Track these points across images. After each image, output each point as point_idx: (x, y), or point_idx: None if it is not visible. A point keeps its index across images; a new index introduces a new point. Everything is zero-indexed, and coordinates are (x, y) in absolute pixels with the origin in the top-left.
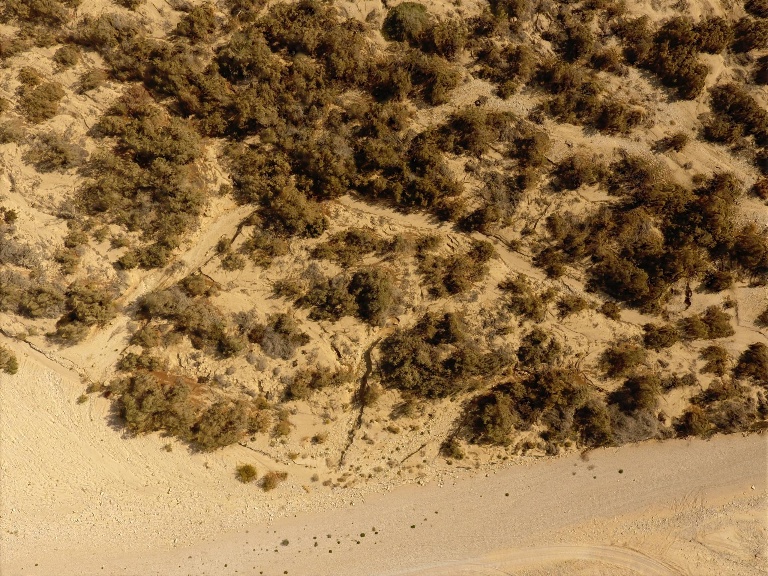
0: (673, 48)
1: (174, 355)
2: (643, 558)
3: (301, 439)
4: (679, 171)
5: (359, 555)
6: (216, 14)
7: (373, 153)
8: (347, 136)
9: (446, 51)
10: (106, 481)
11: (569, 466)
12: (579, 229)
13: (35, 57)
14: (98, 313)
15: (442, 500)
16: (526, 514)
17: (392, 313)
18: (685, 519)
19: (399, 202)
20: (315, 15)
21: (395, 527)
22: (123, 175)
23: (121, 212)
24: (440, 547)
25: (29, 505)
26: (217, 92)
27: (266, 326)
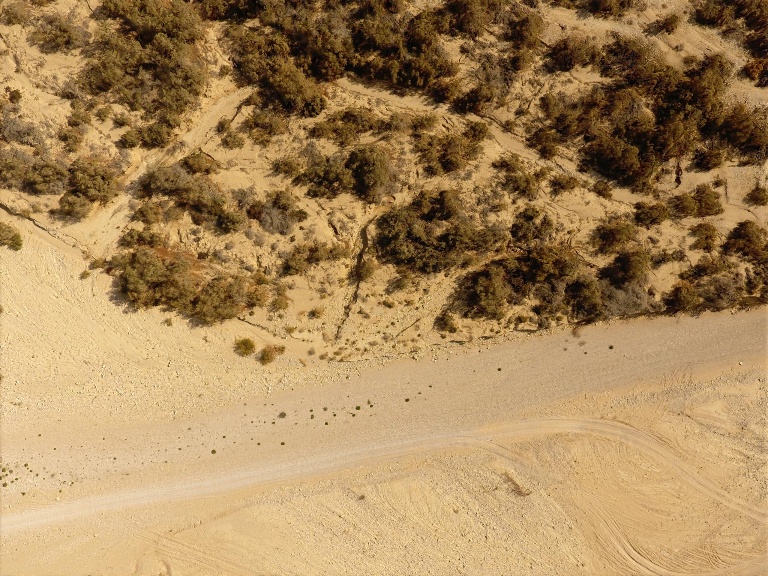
0: None
1: (175, 231)
2: (632, 430)
3: (298, 313)
4: (670, 53)
5: (354, 427)
6: None
7: (370, 30)
8: (345, 18)
9: None
10: (108, 354)
11: (560, 342)
12: (572, 109)
13: None
14: (100, 187)
15: (436, 374)
16: (518, 388)
17: (388, 191)
18: (674, 393)
19: (395, 82)
20: None
21: (390, 400)
22: (125, 50)
23: (123, 90)
24: (434, 420)
25: (33, 377)
26: None
27: (265, 202)
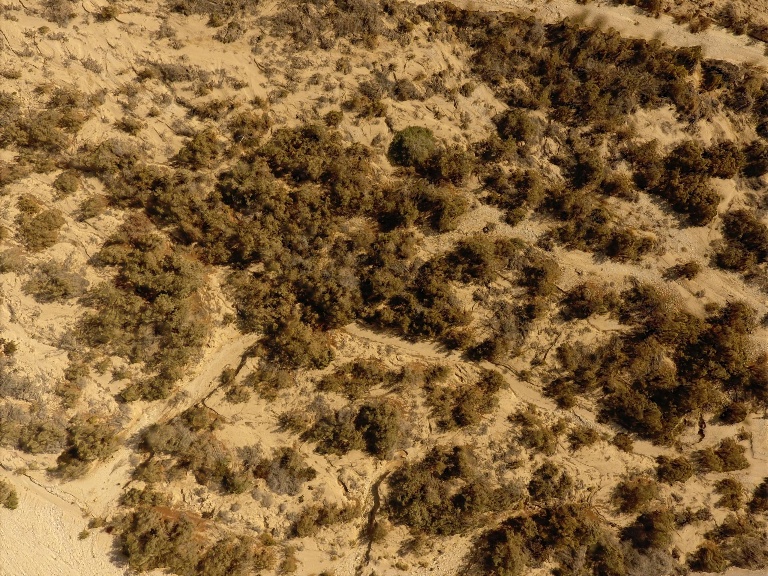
0: (684, 173)
1: (178, 490)
2: None
3: None
4: (691, 299)
5: None
6: (219, 139)
7: (380, 288)
8: (353, 265)
9: (453, 177)
10: None
11: None
12: (590, 360)
13: (34, 184)
14: (100, 451)
15: None
16: None
17: (400, 446)
18: None
19: (406, 332)
20: (320, 143)
21: None
22: (125, 312)
23: (123, 346)
24: None
25: None
26: (220, 222)
27: (271, 461)
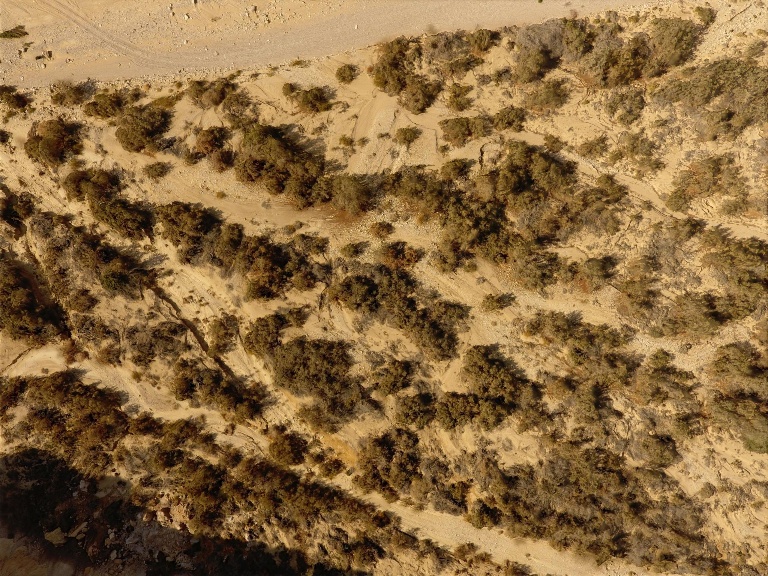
0: None
1: None
2: None
3: None
4: (489, 276)
5: None
6: None
7: None
8: None
9: None
10: None
11: (588, 5)
12: (588, 220)
13: None
14: None
15: None
16: None
17: None
18: None
19: None
20: None
21: None
22: None
23: None
24: None
25: None
26: None
27: None
